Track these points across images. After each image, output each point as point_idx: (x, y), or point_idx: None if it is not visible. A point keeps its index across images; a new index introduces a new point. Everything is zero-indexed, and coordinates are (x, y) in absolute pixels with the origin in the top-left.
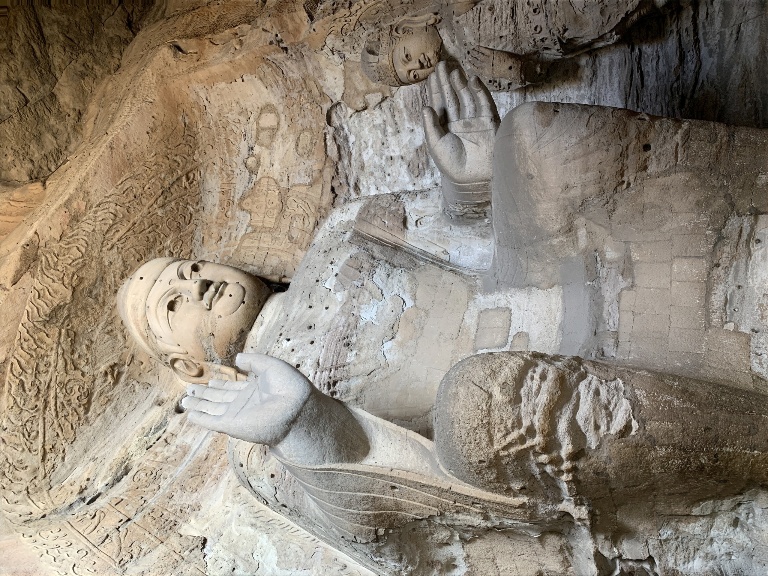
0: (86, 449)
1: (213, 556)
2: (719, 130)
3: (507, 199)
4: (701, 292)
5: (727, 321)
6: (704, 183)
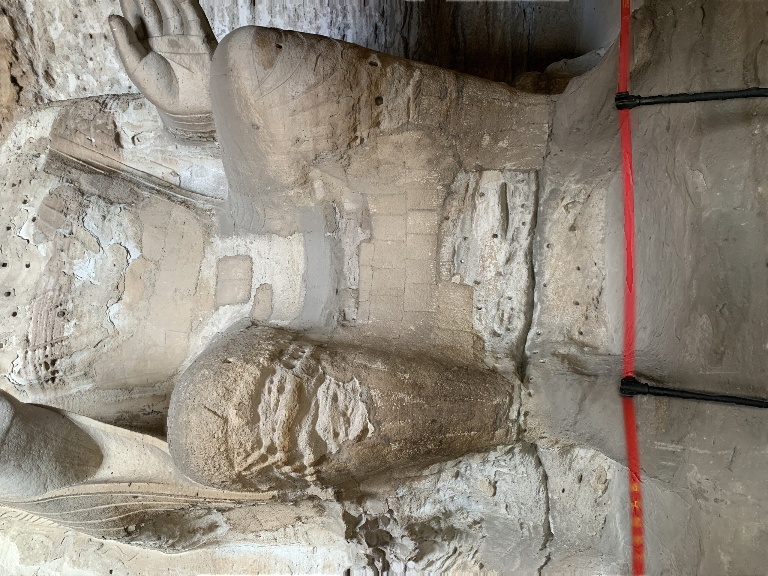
0: None
1: None
2: (449, 83)
3: (232, 146)
4: (433, 245)
5: (455, 273)
6: (435, 142)
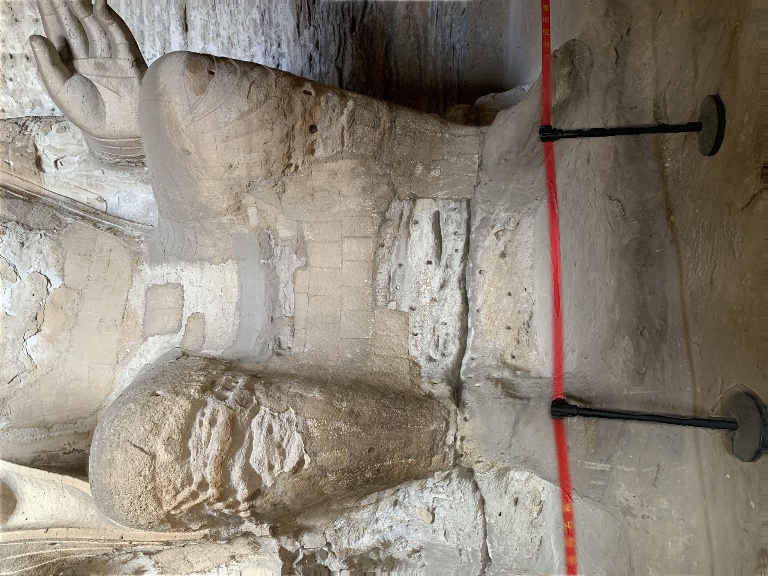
0: None
1: None
2: (382, 114)
3: (162, 172)
4: (368, 271)
5: (390, 300)
6: (369, 171)
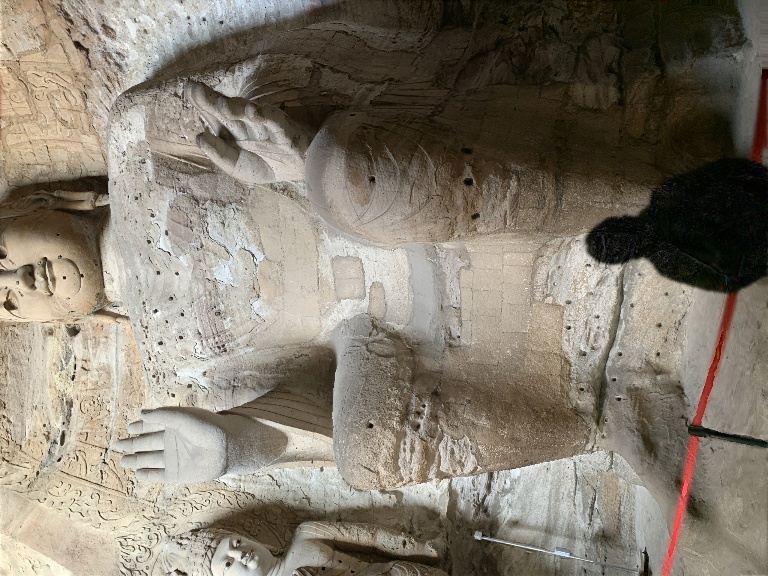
0: (21, 404)
1: None
2: (548, 192)
3: None
4: (528, 273)
5: (548, 294)
6: (531, 235)
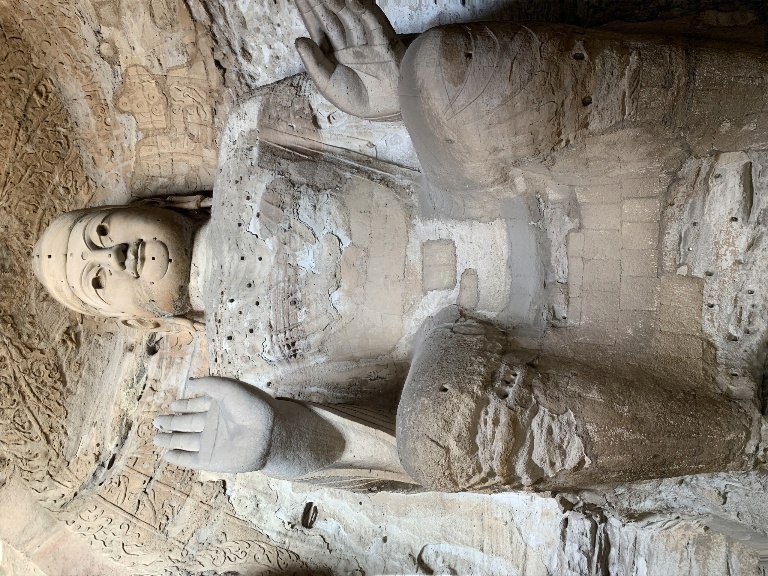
0: (82, 417)
1: (236, 496)
2: (676, 66)
3: (427, 154)
4: (654, 233)
5: (681, 263)
6: (657, 136)
